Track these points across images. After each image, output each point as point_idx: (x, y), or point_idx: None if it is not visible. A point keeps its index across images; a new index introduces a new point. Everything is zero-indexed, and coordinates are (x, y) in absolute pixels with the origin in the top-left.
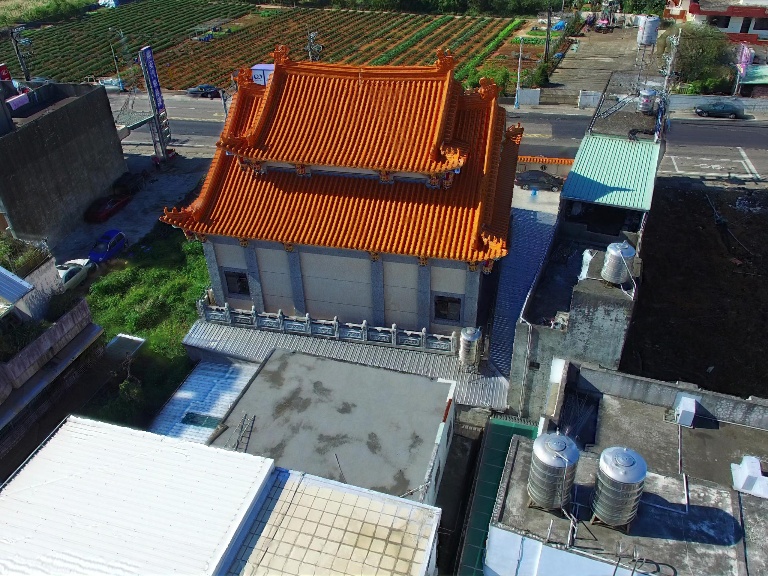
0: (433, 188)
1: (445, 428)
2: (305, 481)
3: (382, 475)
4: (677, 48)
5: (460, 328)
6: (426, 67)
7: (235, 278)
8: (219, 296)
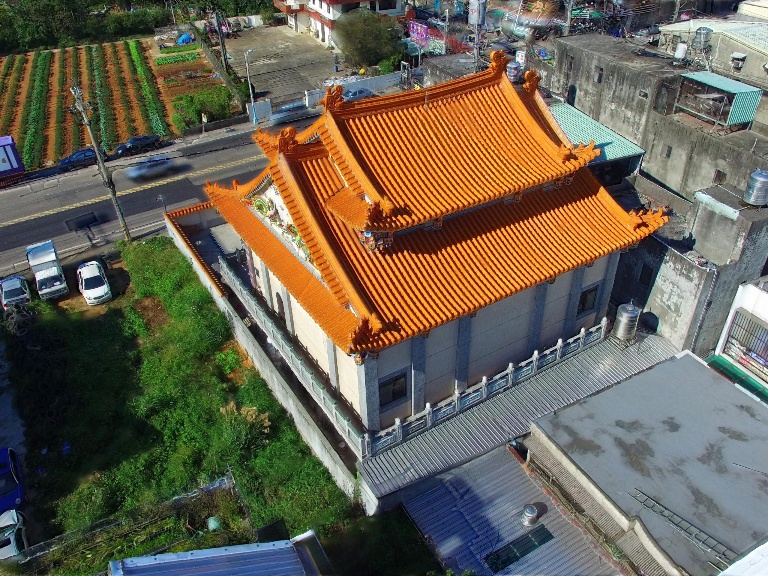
0: (551, 190)
1: None
2: None
3: None
4: (449, 28)
5: (594, 314)
6: (483, 73)
7: (390, 385)
8: (374, 418)
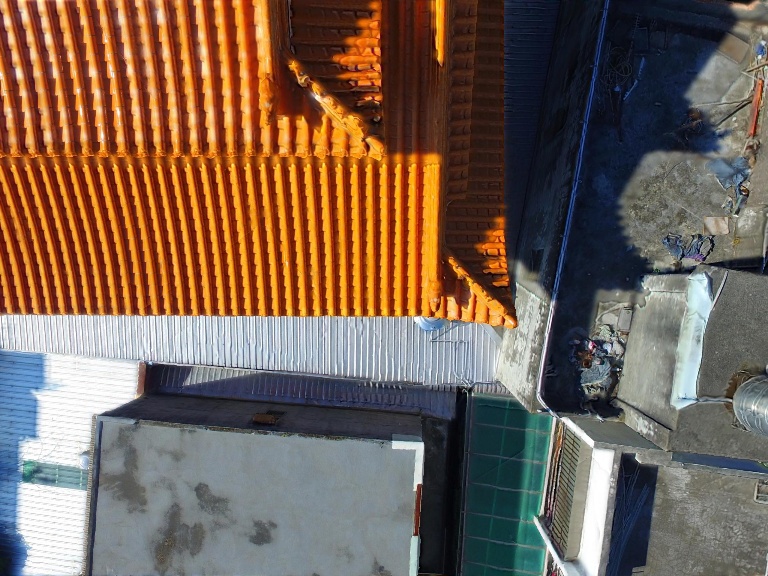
0: None
1: (419, 542)
2: None
3: None
4: None
5: None
6: None
7: None
8: None
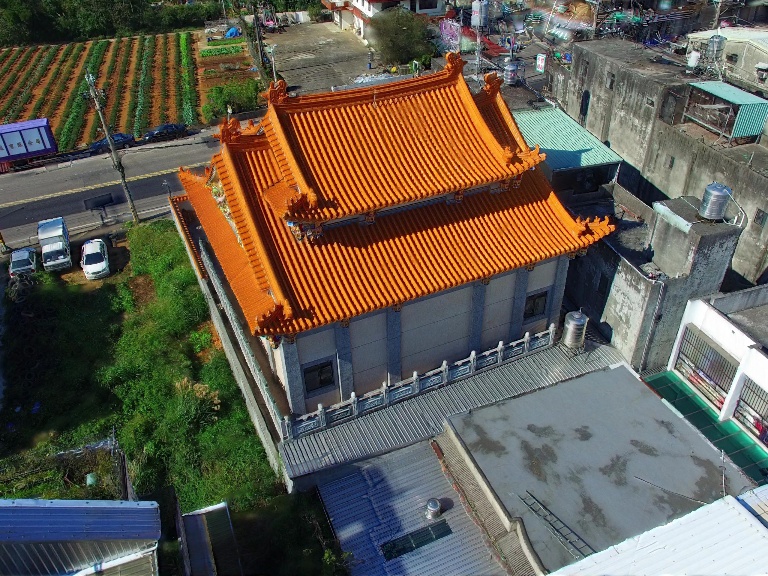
0: (499, 193)
1: None
2: (761, 497)
3: (687, 469)
4: (463, 28)
5: (545, 320)
6: (437, 74)
7: (316, 372)
8: (298, 402)
